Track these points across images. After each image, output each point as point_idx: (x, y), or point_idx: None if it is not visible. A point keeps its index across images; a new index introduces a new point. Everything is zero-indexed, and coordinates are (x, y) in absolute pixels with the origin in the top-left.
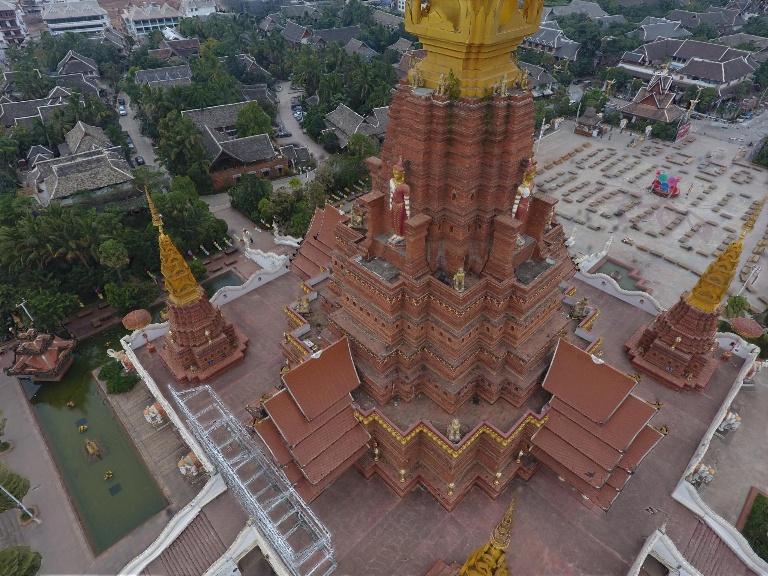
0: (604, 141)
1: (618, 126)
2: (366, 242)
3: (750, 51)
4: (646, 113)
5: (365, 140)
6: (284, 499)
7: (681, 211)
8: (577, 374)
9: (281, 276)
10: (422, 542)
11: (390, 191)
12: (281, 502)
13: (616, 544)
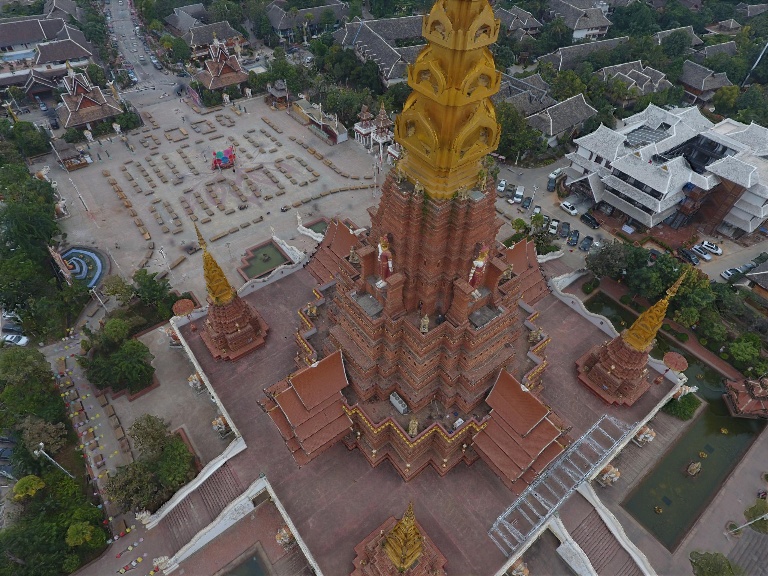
0: (106, 160)
1: (85, 140)
2: (463, 317)
3: (41, 14)
4: (96, 115)
5: (21, 354)
6: (553, 470)
7: (258, 167)
8: (509, 262)
9: (277, 493)
10: (565, 387)
11: (473, 270)
12: (554, 473)
13: (550, 301)
